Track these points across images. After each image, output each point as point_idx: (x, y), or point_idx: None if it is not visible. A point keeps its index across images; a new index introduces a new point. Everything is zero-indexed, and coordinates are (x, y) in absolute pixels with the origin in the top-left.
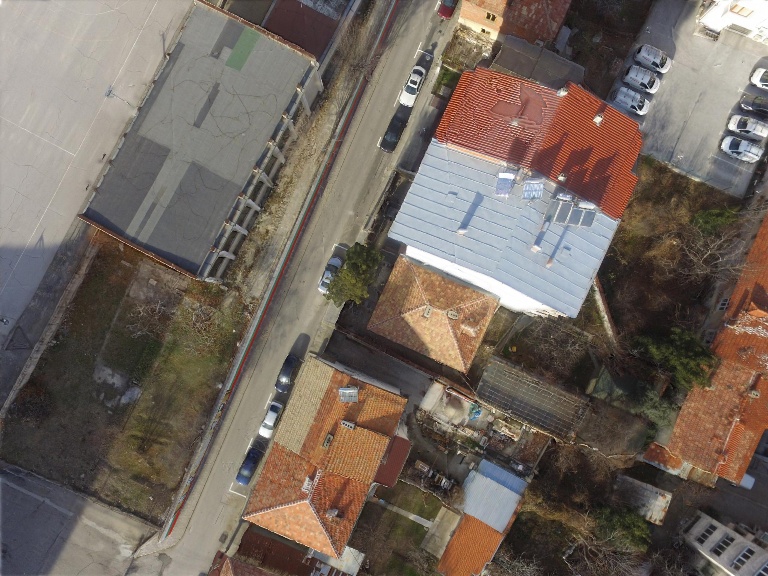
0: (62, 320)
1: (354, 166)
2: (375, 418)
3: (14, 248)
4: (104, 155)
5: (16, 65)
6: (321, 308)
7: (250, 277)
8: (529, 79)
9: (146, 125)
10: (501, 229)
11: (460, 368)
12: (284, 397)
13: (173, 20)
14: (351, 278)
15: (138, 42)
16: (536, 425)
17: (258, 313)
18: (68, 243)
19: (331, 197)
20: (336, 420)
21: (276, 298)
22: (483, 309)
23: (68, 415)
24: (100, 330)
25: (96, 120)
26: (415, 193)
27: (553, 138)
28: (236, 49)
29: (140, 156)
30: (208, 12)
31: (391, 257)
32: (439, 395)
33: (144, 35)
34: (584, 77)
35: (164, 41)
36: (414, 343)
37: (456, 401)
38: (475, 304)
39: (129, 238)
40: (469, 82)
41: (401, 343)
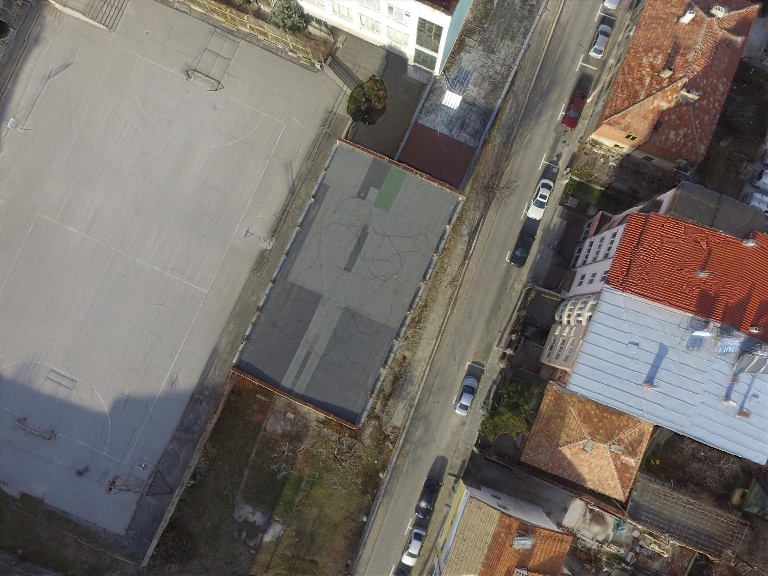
0: (199, 459)
1: (483, 282)
2: (544, 560)
3: (149, 390)
4: (258, 308)
5: (142, 202)
6: (457, 429)
7: (390, 406)
8: (711, 227)
9: (295, 271)
10: (691, 383)
11: (619, 497)
12: (424, 522)
13: (300, 148)
14: (517, 421)
15: (265, 172)
16: (693, 546)
17: (400, 443)
18: (204, 382)
19: (462, 315)
20: (508, 567)
21: (411, 421)
22: (640, 436)
23: (210, 557)
24: (238, 467)
25: (227, 254)
26: (592, 342)
27: (742, 290)
28: (383, 189)
29: (291, 303)
30: (352, 152)
31: (529, 376)
32: (581, 511)
33: (271, 165)
34: (713, 182)
35: (292, 170)
36: (571, 473)
37: (599, 517)
38: (633, 432)
39: (285, 390)
40: (639, 225)
41: (557, 474)
